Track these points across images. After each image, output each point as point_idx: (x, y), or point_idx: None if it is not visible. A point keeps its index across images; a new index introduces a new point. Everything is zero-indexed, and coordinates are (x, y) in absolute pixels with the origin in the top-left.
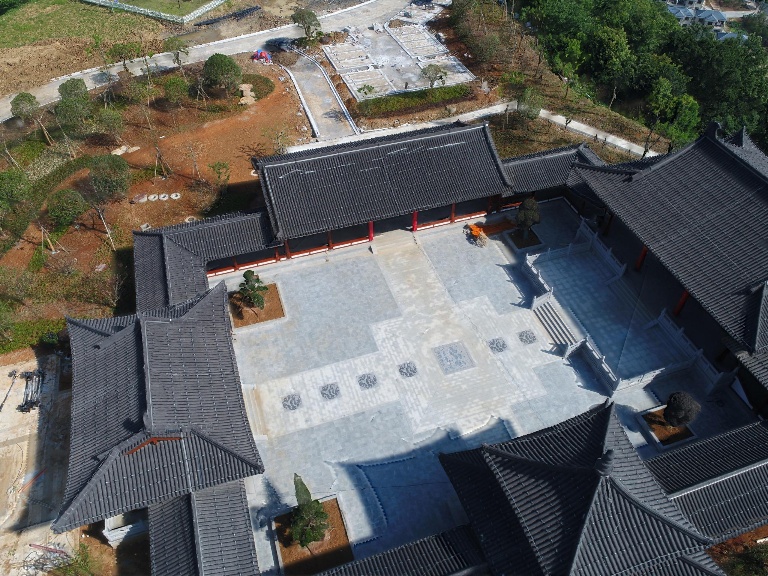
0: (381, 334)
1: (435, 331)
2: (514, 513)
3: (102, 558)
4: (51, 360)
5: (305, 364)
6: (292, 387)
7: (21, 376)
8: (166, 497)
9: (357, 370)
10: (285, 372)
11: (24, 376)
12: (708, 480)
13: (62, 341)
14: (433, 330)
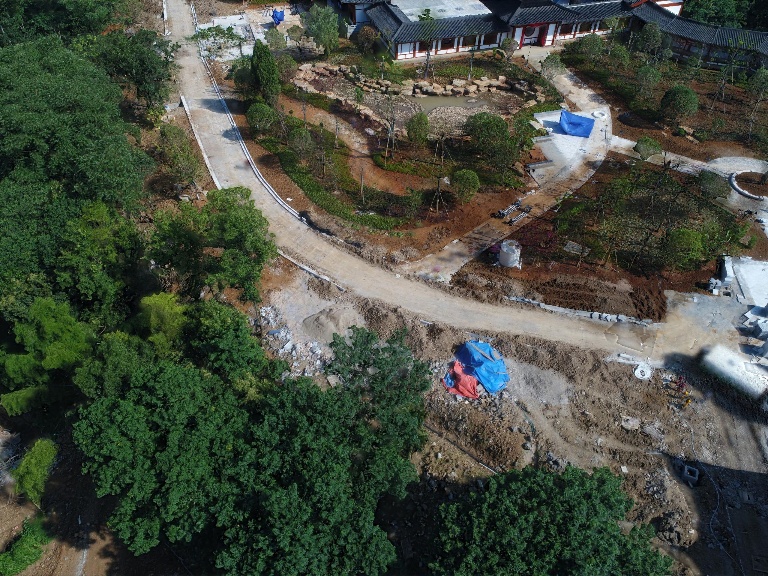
0: (446, 1)
1: (471, 1)
2: (504, 1)
3: (344, 40)
4: (298, 5)
5: (413, 7)
6: (409, 11)
7: (287, 8)
8: (376, 1)
9: (437, 8)
10: (405, 8)
11: (288, 8)
12: (578, 4)
13: (300, 0)
14: (470, 1)
